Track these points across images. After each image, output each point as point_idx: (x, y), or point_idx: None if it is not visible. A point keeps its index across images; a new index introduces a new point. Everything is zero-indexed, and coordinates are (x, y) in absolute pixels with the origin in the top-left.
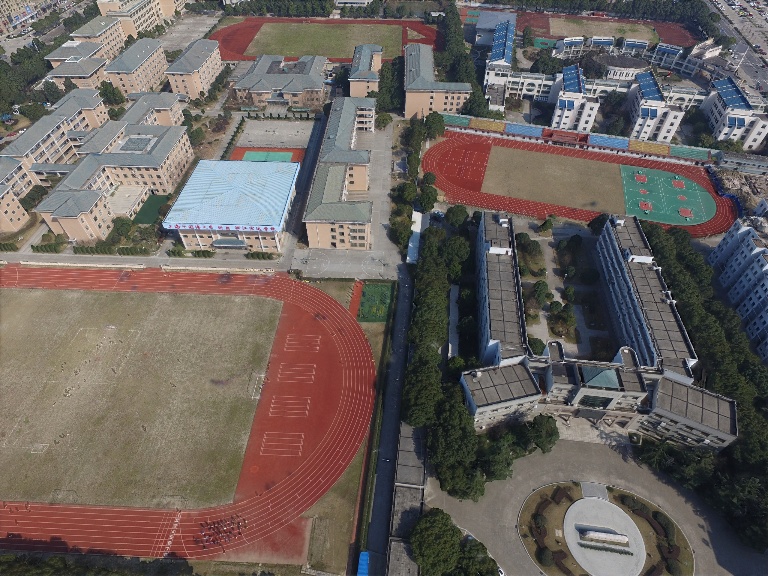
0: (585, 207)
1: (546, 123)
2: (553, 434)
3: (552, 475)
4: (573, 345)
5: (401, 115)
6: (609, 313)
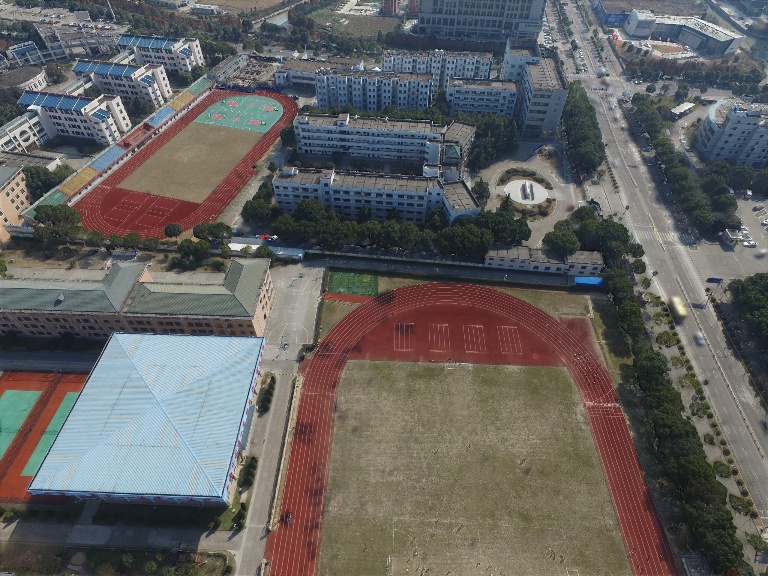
0: (247, 149)
1: (95, 146)
2: (487, 183)
3: (496, 204)
4: None
5: None
6: (369, 160)
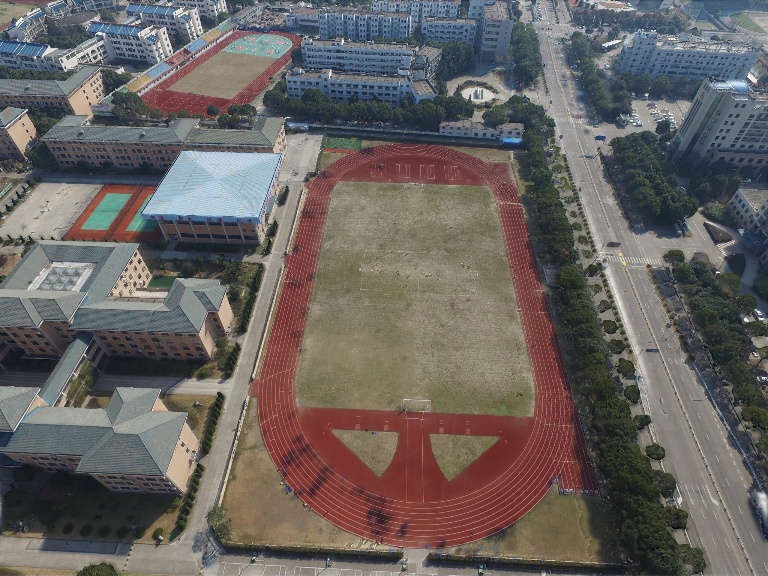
0: (265, 68)
1: (147, 65)
2: (445, 82)
3: None
4: None
5: None
6: None
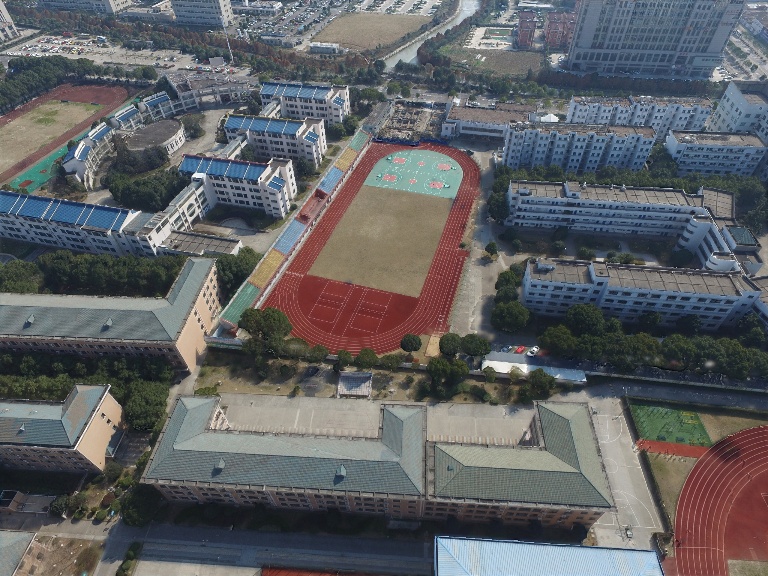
0: (442, 221)
1: (265, 218)
2: None
3: None
4: (647, 263)
5: (180, 379)
6: (596, 236)
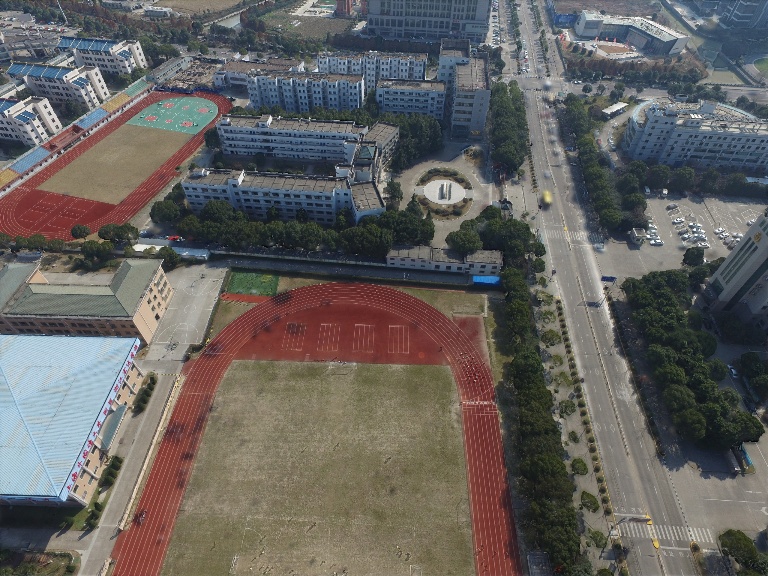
0: (174, 150)
1: (22, 148)
2: (399, 184)
3: None
4: None
5: None
6: (293, 161)
